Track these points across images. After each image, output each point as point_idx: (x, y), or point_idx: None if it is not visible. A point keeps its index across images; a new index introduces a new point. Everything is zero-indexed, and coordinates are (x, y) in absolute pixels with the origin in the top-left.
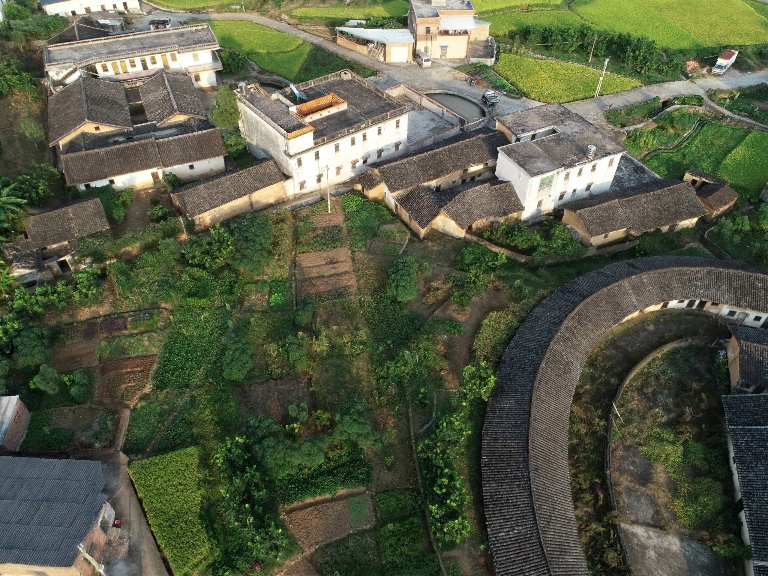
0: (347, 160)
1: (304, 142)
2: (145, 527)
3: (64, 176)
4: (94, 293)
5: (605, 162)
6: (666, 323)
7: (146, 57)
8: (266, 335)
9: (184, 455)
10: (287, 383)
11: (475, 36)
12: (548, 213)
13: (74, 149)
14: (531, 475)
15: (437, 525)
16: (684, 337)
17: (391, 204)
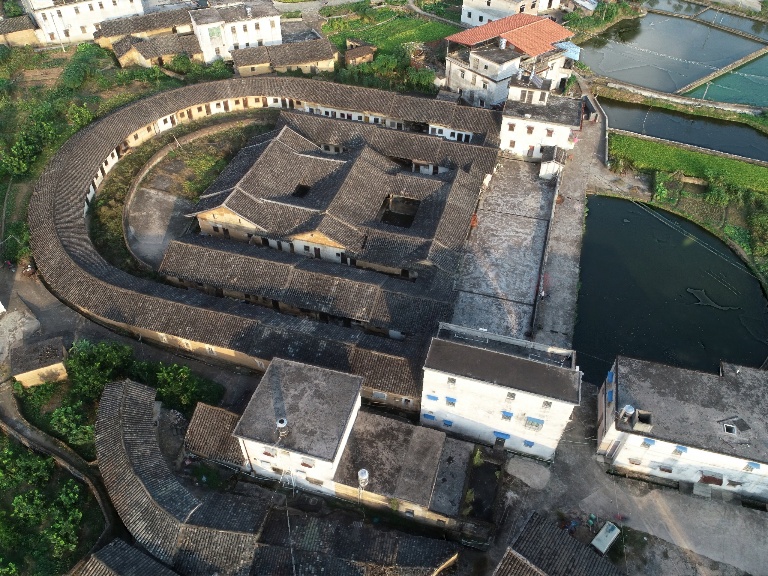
0: (90, 22)
1: (44, 1)
2: None
3: None
4: None
5: (266, 23)
6: (262, 114)
7: None
8: None
9: None
10: None
11: None
12: (229, 60)
13: None
14: (75, 147)
15: None
16: None
17: None
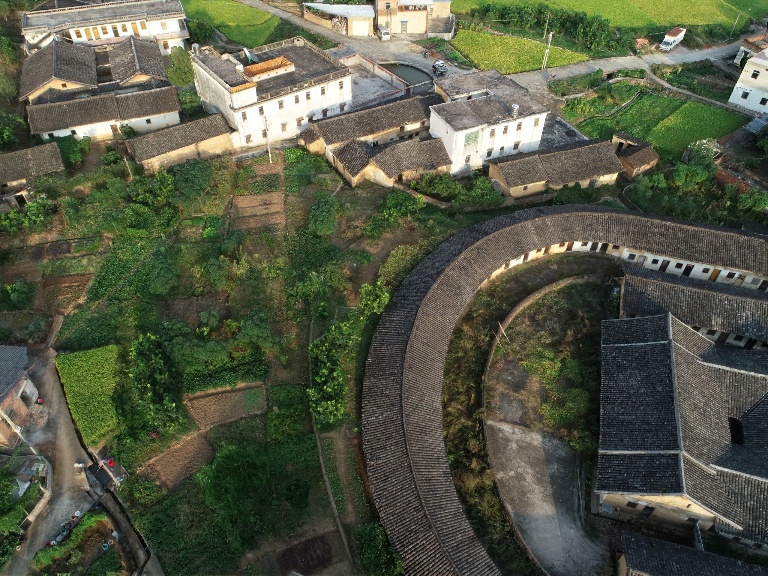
0: (292, 117)
1: (248, 97)
2: (64, 405)
3: (29, 125)
4: (42, 220)
5: (530, 121)
6: (569, 264)
7: (117, 25)
8: (195, 261)
9: (105, 351)
10: (207, 299)
11: (437, 13)
12: (477, 169)
13: (41, 103)
14: (404, 371)
15: (314, 407)
16: (582, 275)
17: (330, 157)
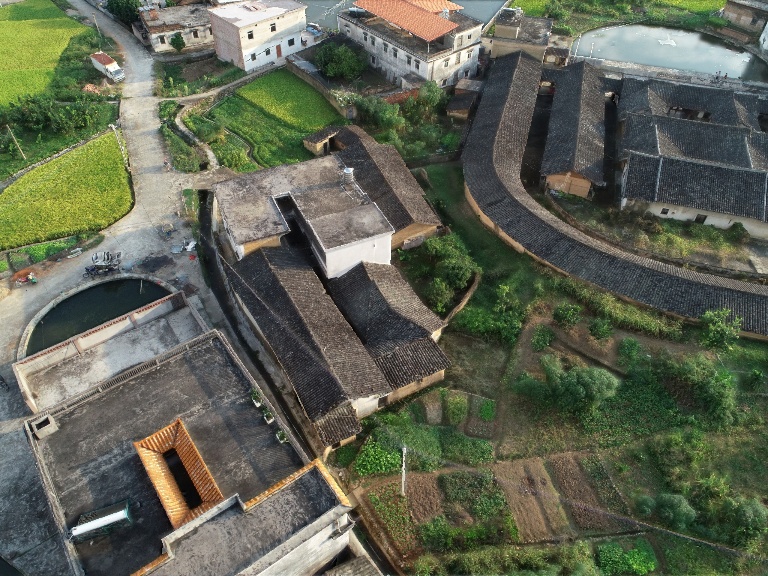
0: None
1: None
2: None
3: None
4: None
5: None
6: None
7: None
8: (715, 569)
9: None
10: None
11: None
12: None
13: None
14: None
15: None
16: (550, 204)
17: (371, 409)
